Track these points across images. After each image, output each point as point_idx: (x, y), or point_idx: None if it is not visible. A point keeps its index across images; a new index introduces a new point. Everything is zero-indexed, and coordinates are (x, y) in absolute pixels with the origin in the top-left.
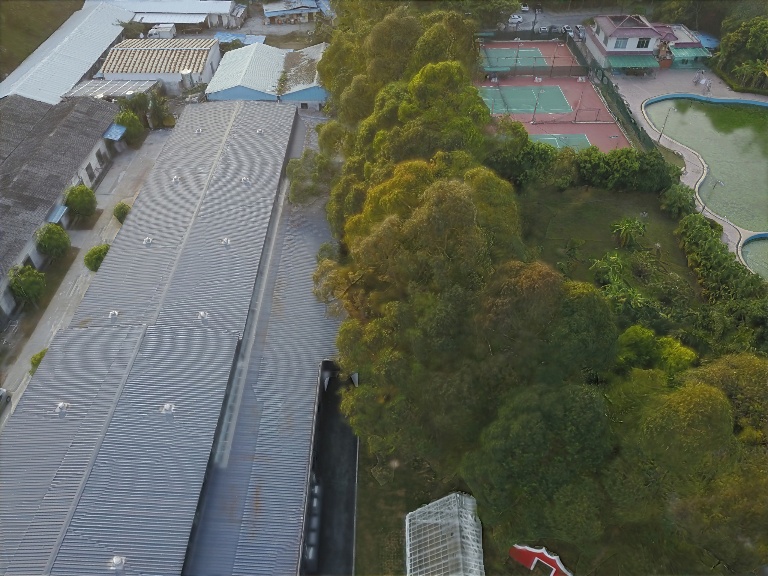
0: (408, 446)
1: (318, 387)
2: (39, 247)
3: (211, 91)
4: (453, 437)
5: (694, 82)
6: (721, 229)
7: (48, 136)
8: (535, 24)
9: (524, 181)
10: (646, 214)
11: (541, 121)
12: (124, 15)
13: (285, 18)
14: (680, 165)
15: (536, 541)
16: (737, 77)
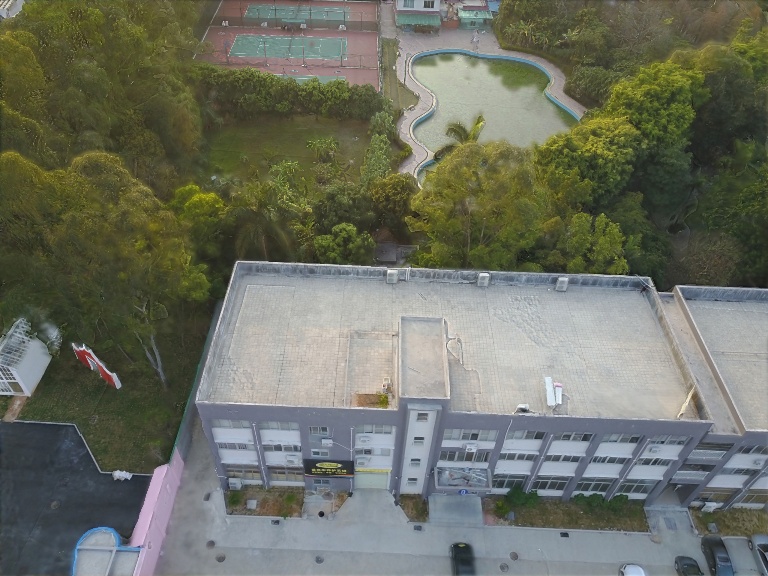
0: None
1: None
2: None
3: None
4: None
5: (471, 40)
6: (408, 150)
7: None
8: None
9: (244, 103)
10: (357, 139)
11: (312, 65)
12: None
13: None
14: (413, 103)
15: (105, 351)
16: (507, 37)
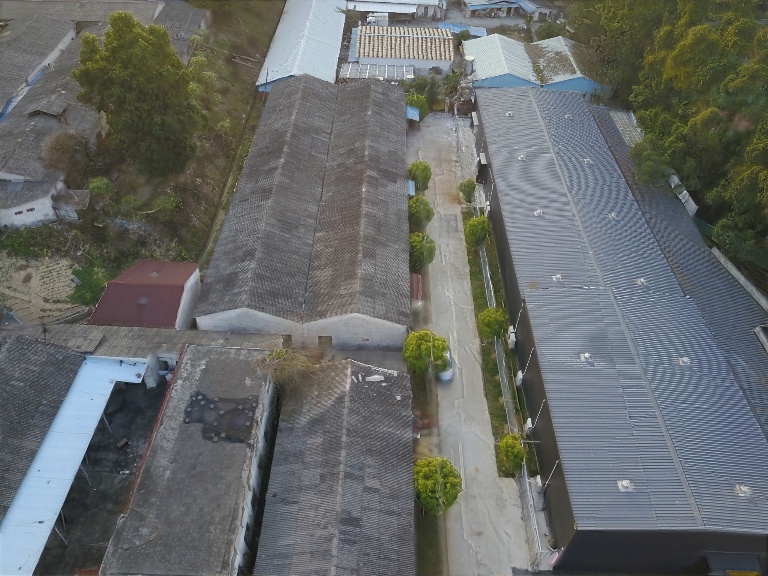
0: None
1: None
2: (411, 217)
3: (477, 78)
4: None
5: None
6: None
7: (367, 114)
8: None
9: None
10: None
11: None
12: (339, 3)
13: (485, 12)
14: None
15: None
16: None
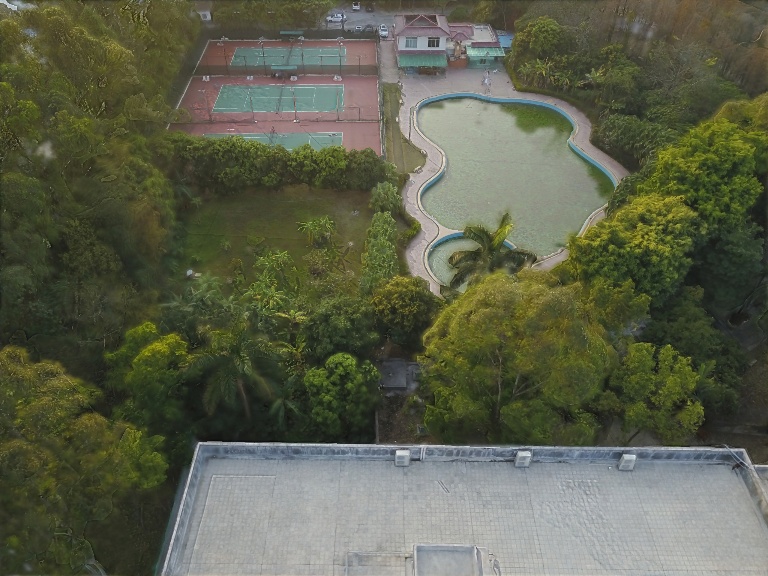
0: None
1: None
2: None
3: None
4: None
5: (482, 81)
6: (416, 227)
7: None
8: None
9: (225, 179)
10: (357, 212)
11: (305, 119)
12: None
13: None
14: (419, 164)
15: None
16: (522, 77)
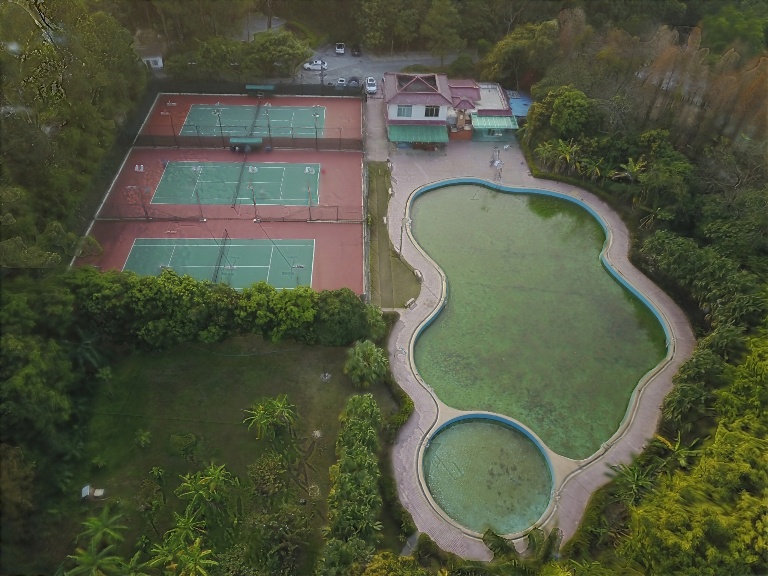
0: None
1: None
2: None
3: None
4: None
5: (490, 162)
6: (408, 410)
7: None
8: (323, 77)
9: (146, 337)
10: (328, 376)
11: (268, 218)
12: None
13: None
14: (412, 293)
15: None
16: (539, 159)
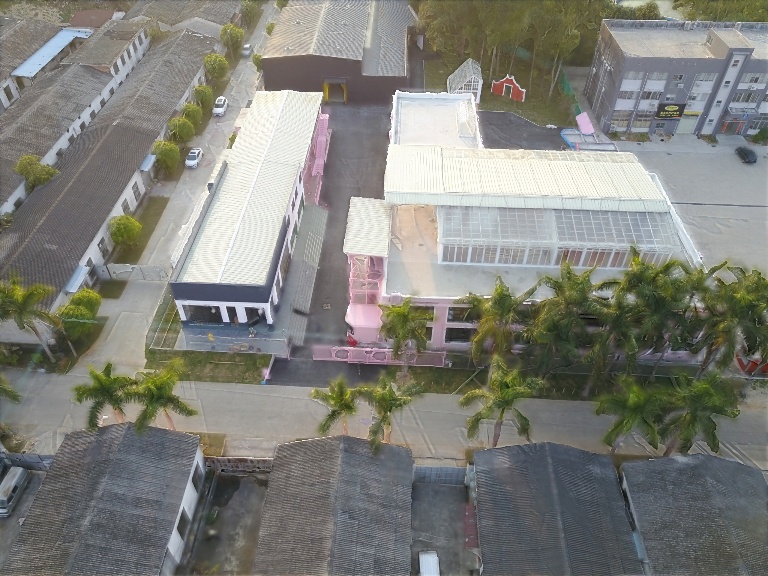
0: (453, 2)
1: (406, 32)
2: None
3: None
4: (470, 6)
5: None
6: None
7: None
8: None
9: None
10: None
11: None
12: None
13: None
14: None
15: None
16: None
